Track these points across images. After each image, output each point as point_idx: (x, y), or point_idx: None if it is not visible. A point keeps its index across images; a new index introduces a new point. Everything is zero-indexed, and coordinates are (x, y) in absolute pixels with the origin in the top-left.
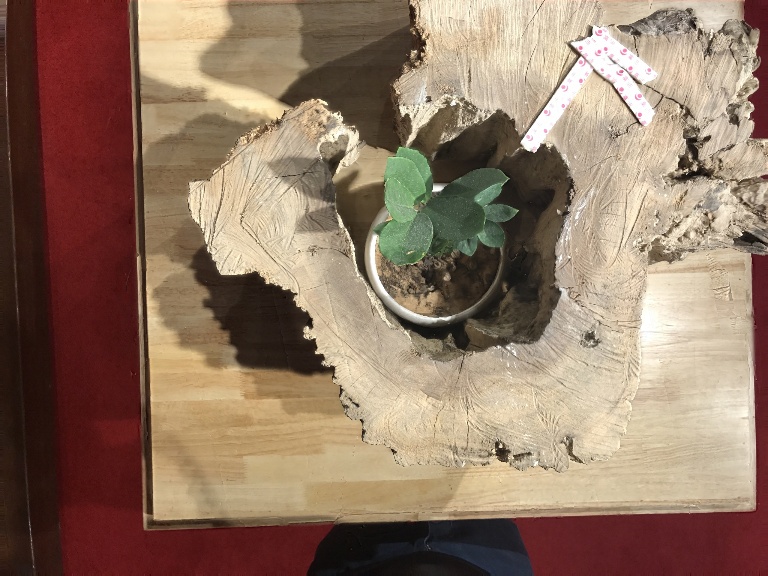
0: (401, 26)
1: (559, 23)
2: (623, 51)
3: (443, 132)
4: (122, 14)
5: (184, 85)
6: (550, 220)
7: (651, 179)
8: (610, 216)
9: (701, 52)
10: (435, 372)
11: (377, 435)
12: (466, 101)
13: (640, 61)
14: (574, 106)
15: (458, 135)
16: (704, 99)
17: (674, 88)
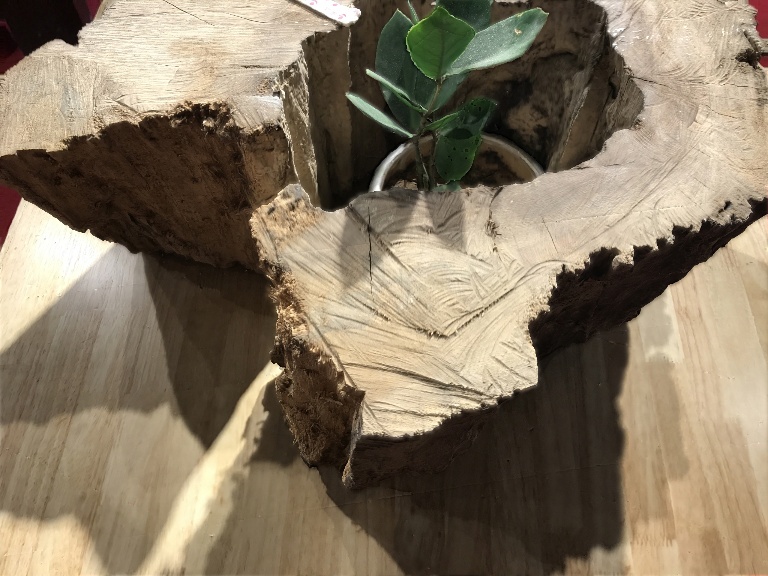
0: (144, 282)
1: None
2: None
3: (308, 163)
4: None
5: None
6: None
7: None
8: None
9: None
10: (660, 107)
11: (767, 184)
12: (284, 72)
13: None
14: None
15: None
16: None
17: None
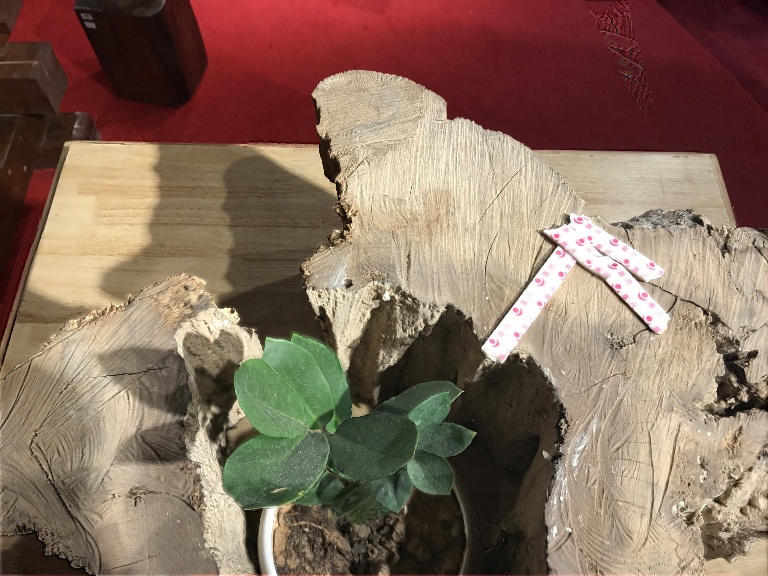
0: None
1: (526, 210)
2: (613, 241)
3: (380, 350)
4: (27, 229)
5: (76, 304)
6: (535, 475)
7: (682, 409)
8: (627, 463)
9: (717, 249)
10: None
11: None
12: (403, 292)
13: (638, 254)
14: (555, 305)
15: (401, 355)
16: (735, 303)
17: (690, 289)
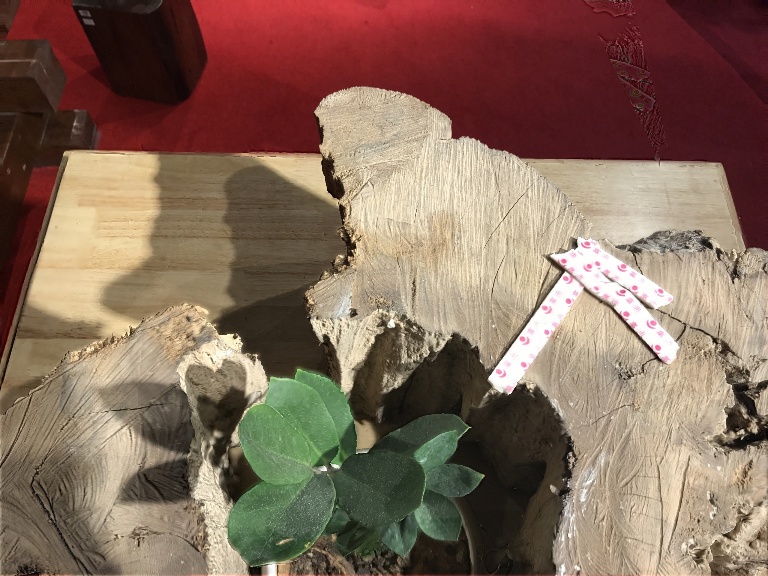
0: None
1: (533, 233)
2: (621, 267)
3: (385, 373)
4: (27, 241)
5: (76, 319)
6: (542, 505)
7: (691, 441)
8: (636, 498)
9: (726, 274)
10: None
11: None
12: (408, 320)
13: (646, 280)
14: (562, 334)
15: (406, 379)
16: (745, 331)
17: (699, 316)
